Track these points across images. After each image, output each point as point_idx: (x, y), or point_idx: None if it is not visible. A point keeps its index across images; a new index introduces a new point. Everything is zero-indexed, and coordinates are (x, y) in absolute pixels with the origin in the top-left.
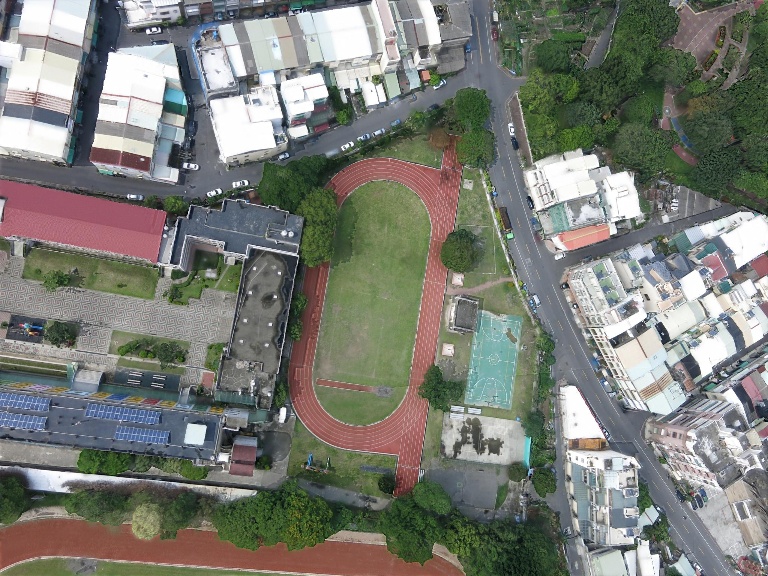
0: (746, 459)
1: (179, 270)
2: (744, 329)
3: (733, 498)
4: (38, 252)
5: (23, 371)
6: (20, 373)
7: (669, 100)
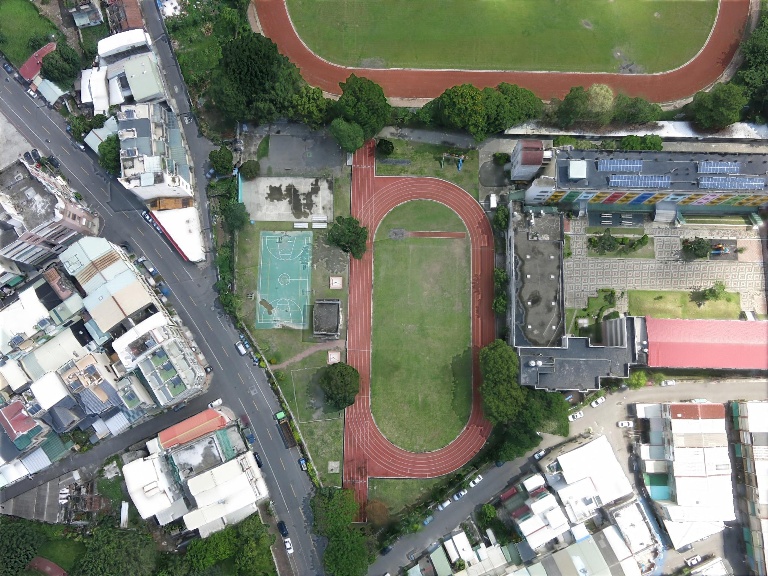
0: None
1: None
2: None
3: None
4: (733, 317)
5: (714, 216)
6: (716, 214)
7: None
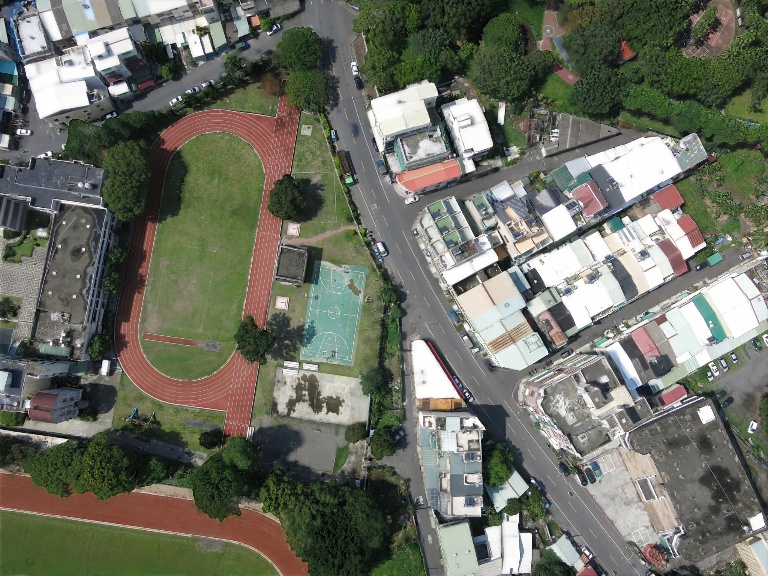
0: (605, 420)
1: (10, 230)
2: (634, 272)
3: (636, 474)
4: None
5: None
6: None
7: (551, 18)
